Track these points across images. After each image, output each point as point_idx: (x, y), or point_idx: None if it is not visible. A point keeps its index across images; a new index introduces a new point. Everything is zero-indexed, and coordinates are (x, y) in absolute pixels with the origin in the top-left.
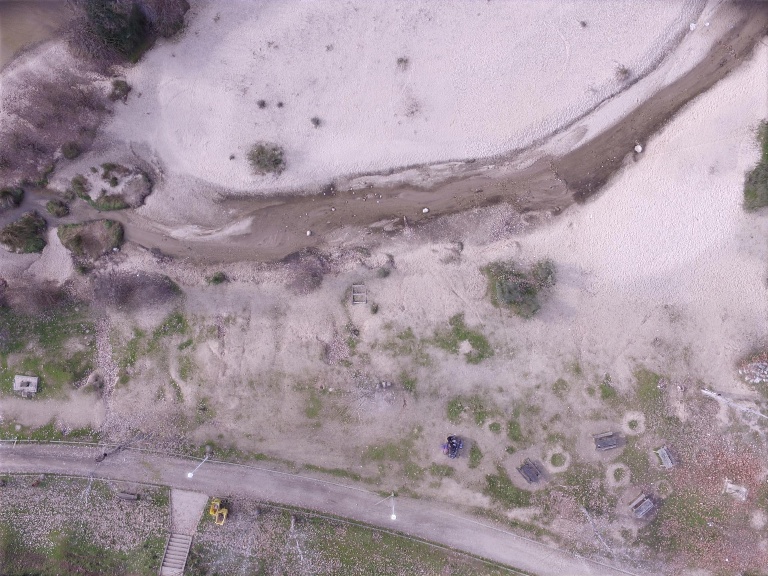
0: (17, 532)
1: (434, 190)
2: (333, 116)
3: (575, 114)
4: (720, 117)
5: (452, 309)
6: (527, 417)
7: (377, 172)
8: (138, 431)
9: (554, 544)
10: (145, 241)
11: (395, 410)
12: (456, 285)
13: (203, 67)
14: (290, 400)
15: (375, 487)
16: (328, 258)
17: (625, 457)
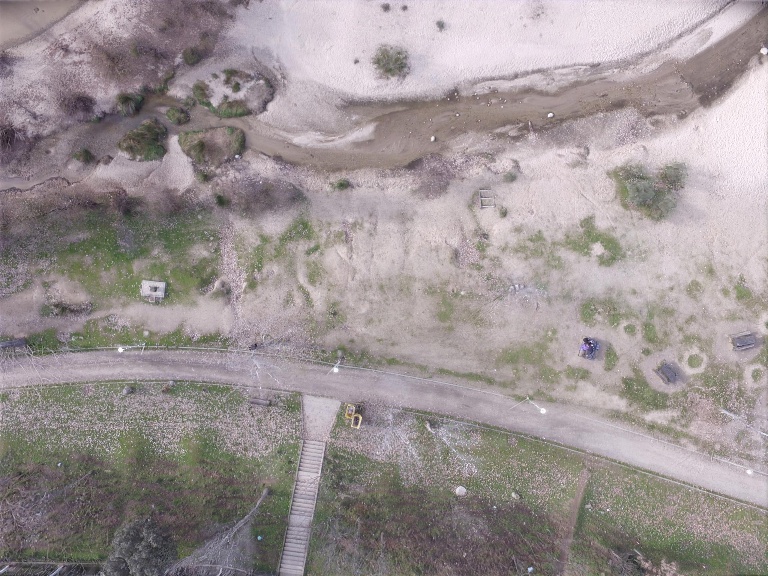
0: (146, 440)
1: (559, 94)
2: (458, 19)
3: (701, 16)
4: None
5: (582, 212)
6: (662, 318)
7: (502, 76)
8: (268, 336)
9: (692, 446)
10: (267, 148)
11: (528, 313)
12: (584, 188)
13: None
14: (422, 304)
15: (510, 391)
16: (452, 164)
17: (762, 357)
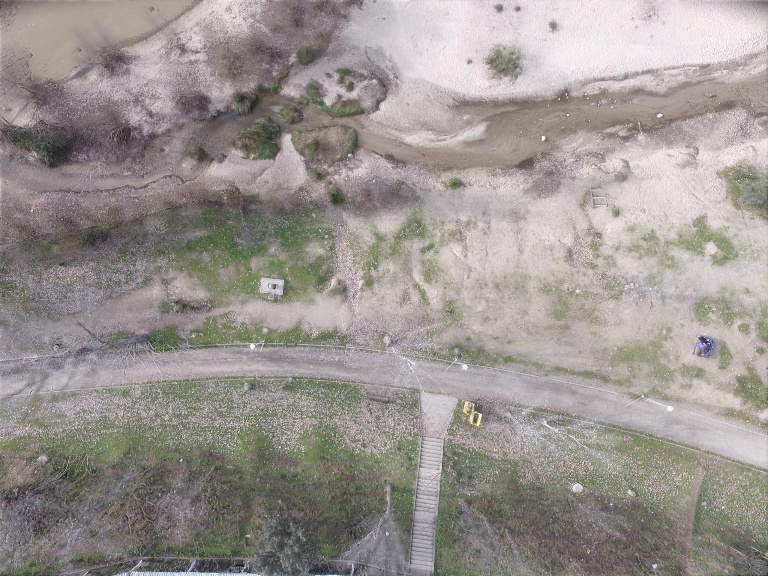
0: (266, 436)
1: (668, 95)
2: (570, 20)
3: None
4: None
5: (694, 211)
6: None
7: (612, 77)
8: (385, 334)
9: None
10: (379, 147)
11: (643, 311)
12: (695, 188)
13: None
14: (537, 302)
15: (625, 389)
16: (562, 164)
17: None
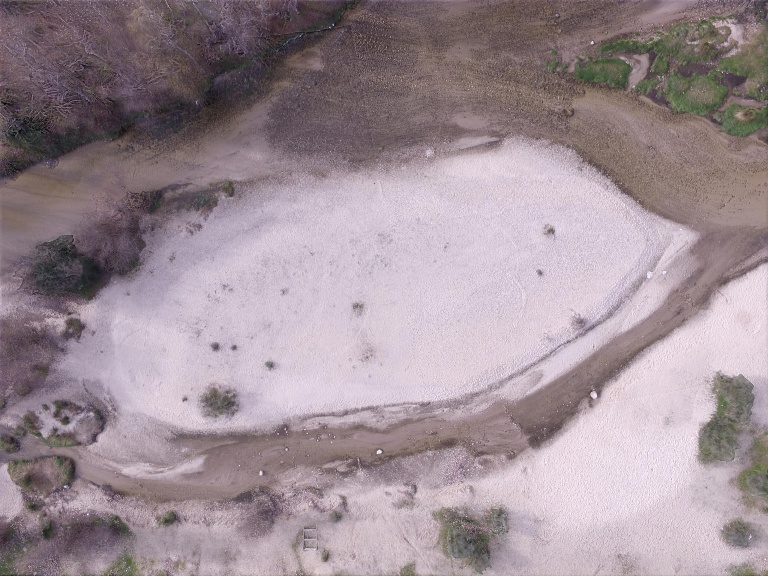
0: None
1: (388, 432)
2: (287, 359)
3: (531, 360)
4: (676, 368)
5: (403, 558)
6: None
7: (331, 413)
8: None
9: None
10: (96, 478)
11: None
12: (408, 532)
13: (158, 307)
14: None
15: None
16: (280, 498)
17: None
